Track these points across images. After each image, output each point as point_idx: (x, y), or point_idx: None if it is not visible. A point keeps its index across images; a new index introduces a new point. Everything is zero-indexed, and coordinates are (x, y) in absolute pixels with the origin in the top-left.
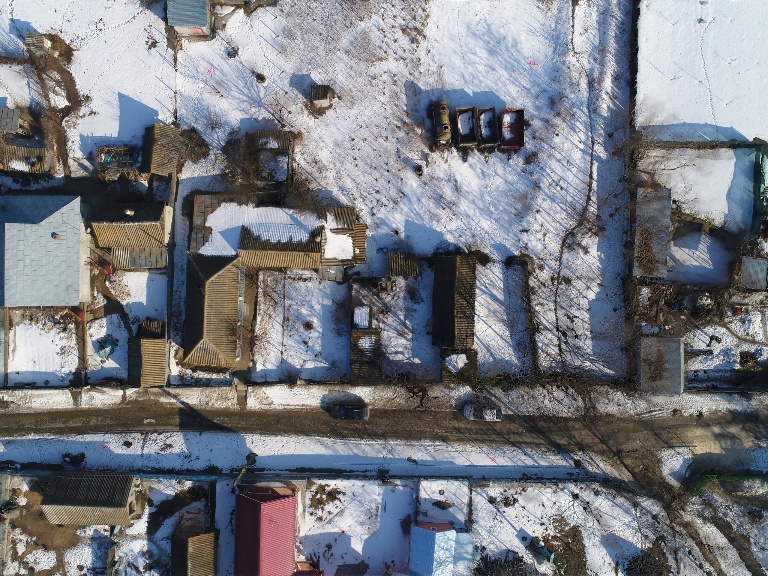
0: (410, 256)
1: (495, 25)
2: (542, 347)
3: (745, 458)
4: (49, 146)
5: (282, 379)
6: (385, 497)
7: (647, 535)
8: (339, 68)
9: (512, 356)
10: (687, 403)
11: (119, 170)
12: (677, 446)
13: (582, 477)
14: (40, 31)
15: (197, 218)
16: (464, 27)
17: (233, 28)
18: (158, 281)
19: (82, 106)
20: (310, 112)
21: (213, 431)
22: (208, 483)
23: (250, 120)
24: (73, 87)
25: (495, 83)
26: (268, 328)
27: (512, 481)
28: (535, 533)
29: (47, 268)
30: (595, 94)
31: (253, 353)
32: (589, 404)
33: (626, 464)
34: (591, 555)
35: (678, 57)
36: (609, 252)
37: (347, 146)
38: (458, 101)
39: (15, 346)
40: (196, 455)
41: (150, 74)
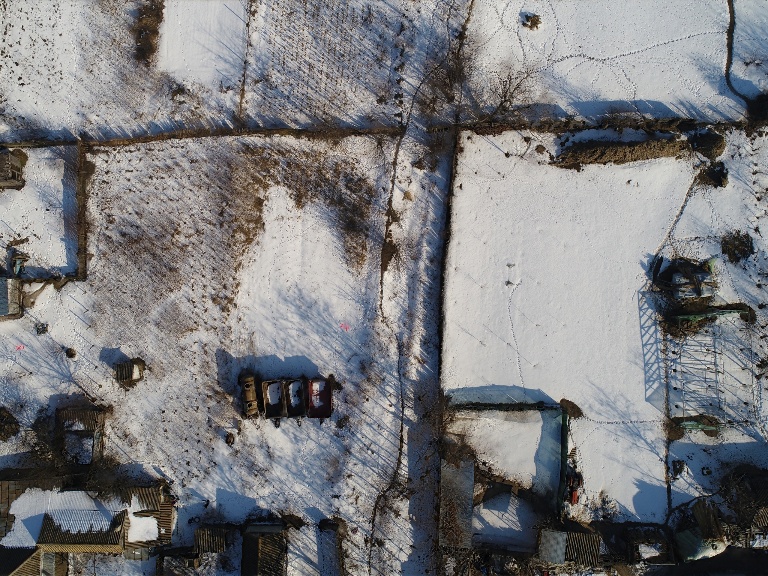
0: (217, 532)
1: (306, 290)
2: None
3: None
4: None
5: None
6: None
7: None
8: (149, 340)
9: None
10: None
11: None
12: None
13: None
14: None
15: (1, 505)
16: (275, 293)
17: (42, 304)
18: None
19: None
20: (121, 384)
21: None
22: None
23: (60, 396)
24: None
25: (307, 347)
26: None
27: None
28: None
29: None
30: (404, 359)
31: None
32: None
33: None
34: None
35: (487, 319)
36: (420, 514)
37: (157, 418)
38: (270, 367)
39: None
40: None
41: None
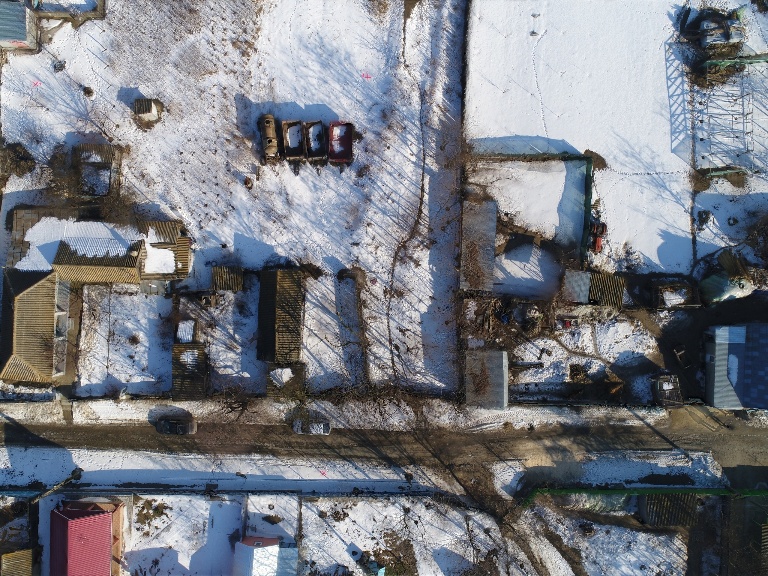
0: (234, 270)
1: (328, 38)
2: (374, 360)
3: (576, 471)
4: None
5: (107, 394)
6: (212, 512)
7: (479, 549)
8: (168, 81)
9: (344, 370)
10: (517, 416)
11: None
12: (509, 459)
13: (414, 491)
14: None
15: (16, 233)
16: (296, 40)
17: (60, 42)
18: None
19: None
20: (139, 125)
21: (39, 446)
22: (26, 499)
23: (76, 134)
24: None
25: (328, 96)
26: (93, 343)
27: (343, 495)
28: (366, 547)
29: None
30: (426, 107)
31: (77, 368)
32: (421, 417)
33: (458, 478)
34: (422, 569)
35: (511, 70)
36: (441, 265)
37: (175, 159)
38: (290, 114)
39: None
40: (20, 471)
41: None
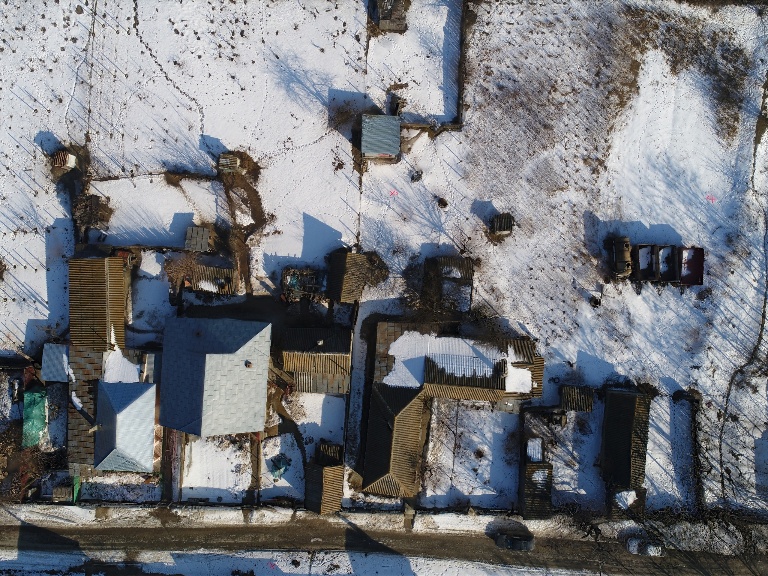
0: (586, 391)
1: (675, 158)
2: (706, 483)
3: None
4: (235, 266)
5: (451, 506)
6: None
7: None
8: (520, 196)
9: (675, 490)
10: None
11: (305, 294)
12: None
13: None
14: (229, 148)
15: (380, 346)
16: (644, 159)
17: (418, 151)
18: (334, 403)
19: (267, 225)
20: (489, 239)
21: (378, 552)
22: None
23: (431, 245)
24: (258, 205)
25: (672, 216)
26: (439, 454)
27: None
28: None
29: (239, 396)
30: None
31: (424, 479)
32: (750, 542)
33: None
34: None
35: None
36: None
37: (525, 275)
38: (635, 233)
39: (191, 462)
40: None
41: (335, 195)
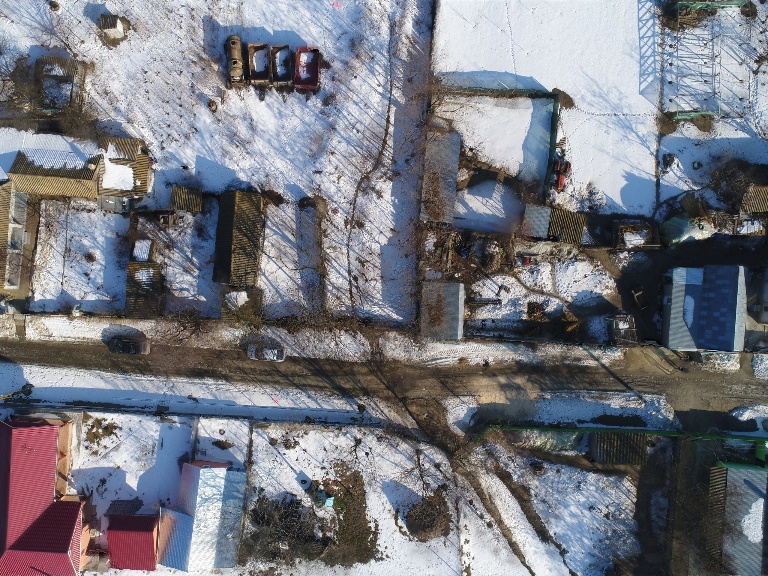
0: (194, 191)
1: None
2: (332, 290)
3: (529, 409)
4: None
5: (60, 310)
6: (162, 434)
7: (429, 483)
8: None
9: (301, 298)
10: (473, 352)
11: None
12: (462, 395)
13: (366, 422)
14: None
15: None
16: None
17: None
18: None
19: None
20: (104, 43)
21: None
22: None
23: (41, 47)
24: None
25: (297, 23)
26: (49, 258)
27: None
28: (315, 477)
29: None
30: (395, 38)
31: (32, 282)
32: (376, 349)
33: (411, 411)
34: (371, 501)
35: (482, 4)
36: (403, 197)
37: (140, 78)
38: (258, 39)
39: None
40: None
41: None
